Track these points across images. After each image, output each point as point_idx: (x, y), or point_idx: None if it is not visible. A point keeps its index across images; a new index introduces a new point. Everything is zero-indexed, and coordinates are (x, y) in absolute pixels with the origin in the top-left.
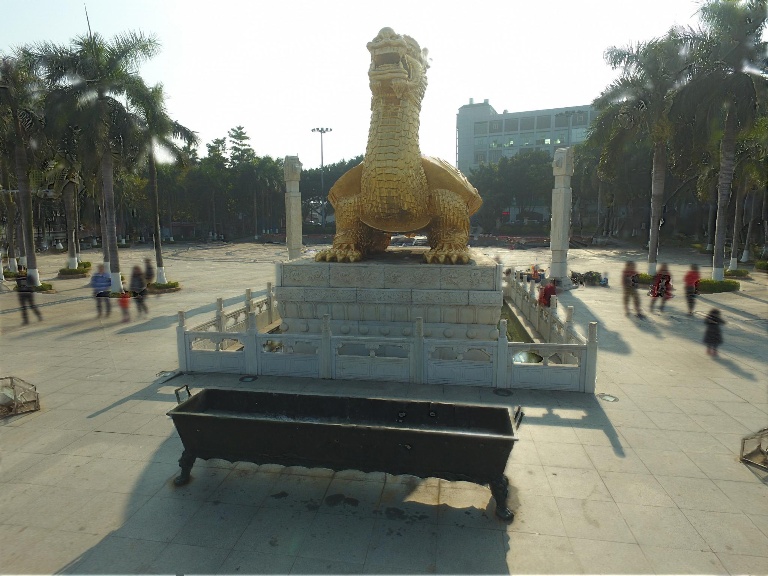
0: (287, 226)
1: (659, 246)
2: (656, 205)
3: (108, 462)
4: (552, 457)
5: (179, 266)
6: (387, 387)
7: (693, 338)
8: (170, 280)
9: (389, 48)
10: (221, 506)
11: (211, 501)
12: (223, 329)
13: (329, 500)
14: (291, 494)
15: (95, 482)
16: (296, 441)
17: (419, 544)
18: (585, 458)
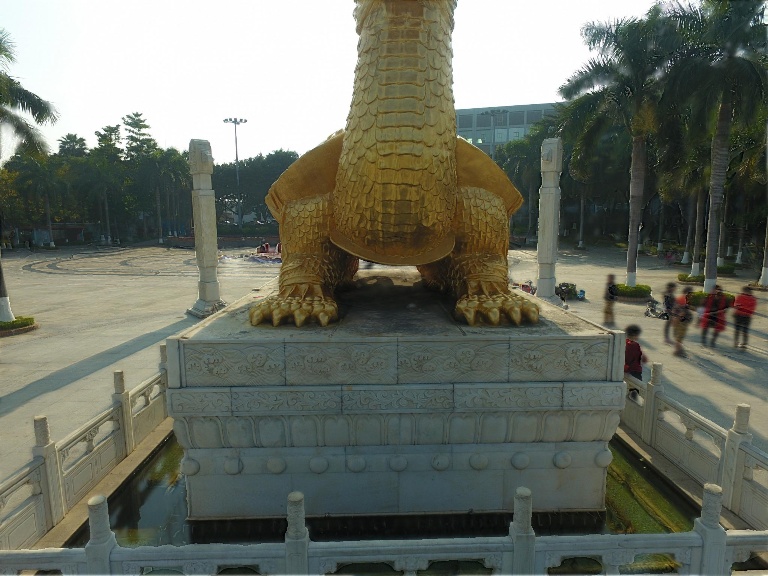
0: (196, 236)
1: (589, 246)
2: (635, 208)
3: None
4: None
5: (50, 284)
6: None
7: None
8: (28, 310)
9: None
10: None
11: None
12: (52, 481)
13: None
14: None
15: None
16: None
17: None
18: None
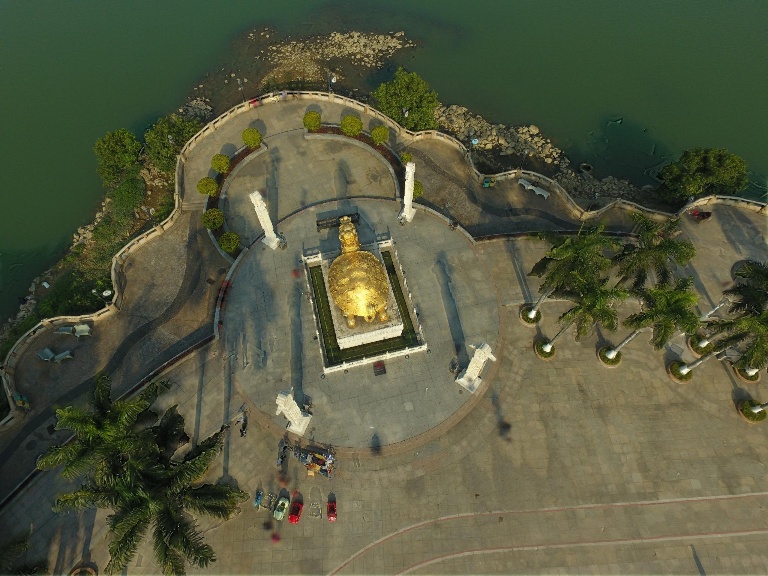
0: None
1: None
2: None
3: (371, 219)
4: (313, 239)
5: (719, 490)
6: None
7: (266, 317)
8: (594, 390)
9: None
10: None
11: None
12: None
13: None
14: None
15: (368, 216)
16: None
17: None
18: (308, 240)
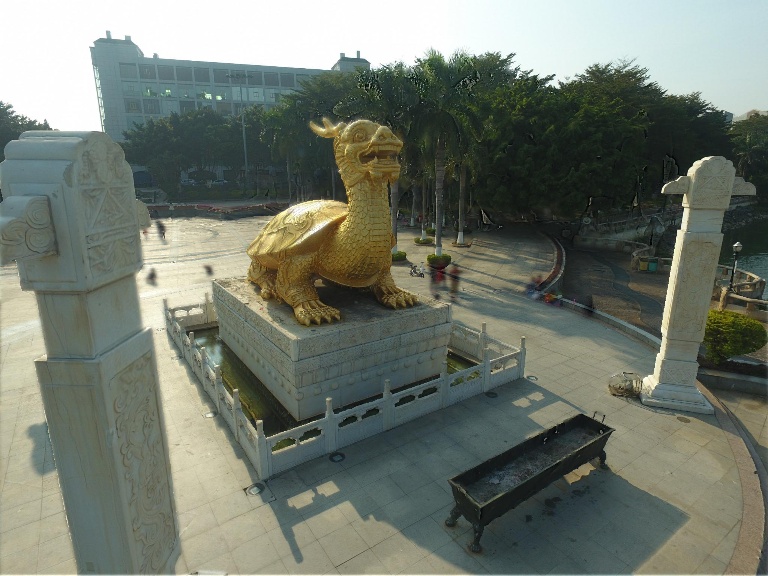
0: None
1: None
2: (395, 200)
3: (409, 573)
4: None
5: None
6: (435, 419)
7: (495, 315)
8: None
9: (390, 146)
10: (521, 544)
11: (512, 545)
12: None
13: (549, 505)
14: (532, 514)
15: None
16: (537, 482)
17: (607, 500)
18: None
